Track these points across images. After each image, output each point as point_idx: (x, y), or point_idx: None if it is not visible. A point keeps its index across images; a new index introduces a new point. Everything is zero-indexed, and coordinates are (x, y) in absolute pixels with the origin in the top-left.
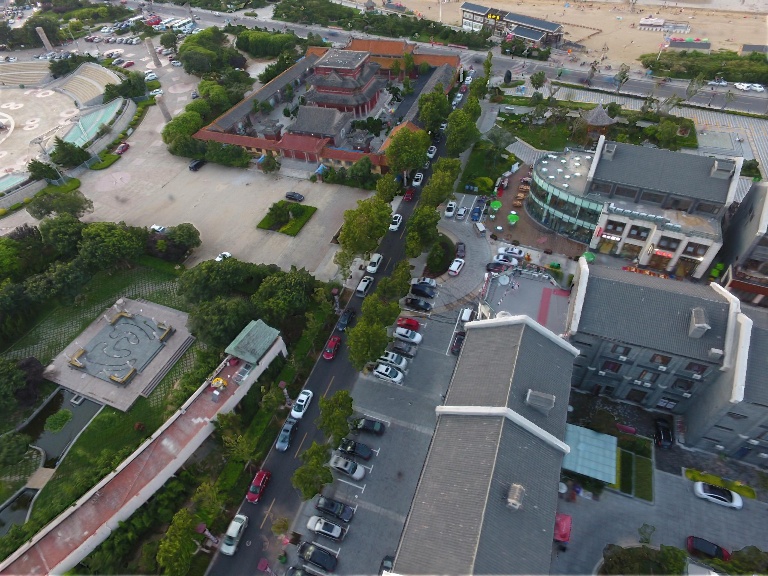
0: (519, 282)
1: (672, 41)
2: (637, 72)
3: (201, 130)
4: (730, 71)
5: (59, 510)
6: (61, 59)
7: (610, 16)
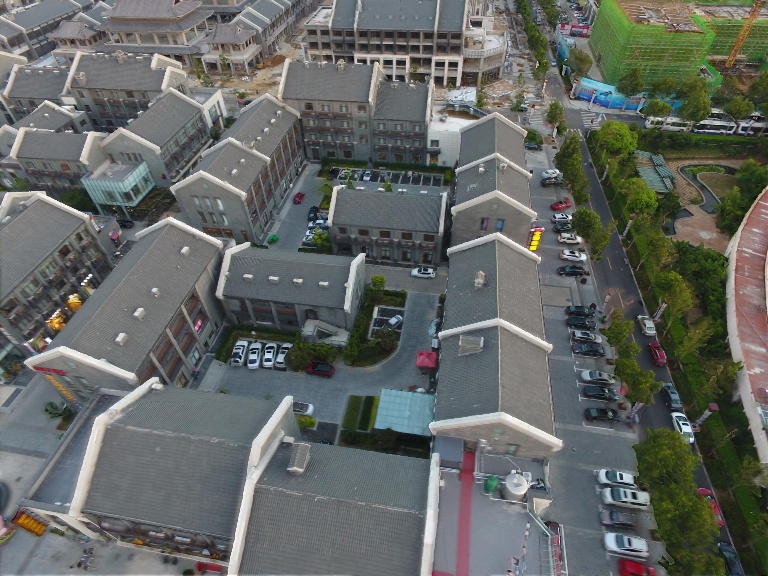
0: None
1: None
2: None
3: None
4: None
5: None
6: None
7: None
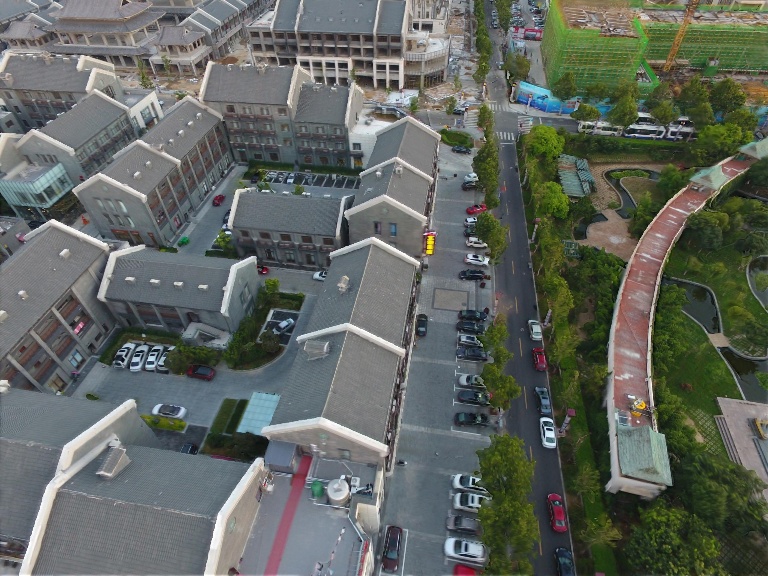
0: None
1: None
2: None
3: None
4: None
5: (669, 314)
6: None
7: None
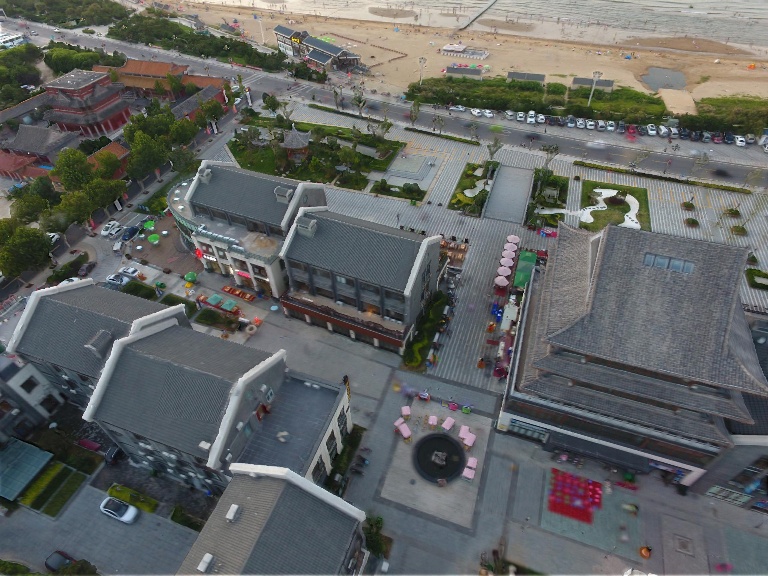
0: None
1: (449, 67)
2: (395, 96)
3: None
4: (469, 97)
5: None
6: None
7: (428, 41)
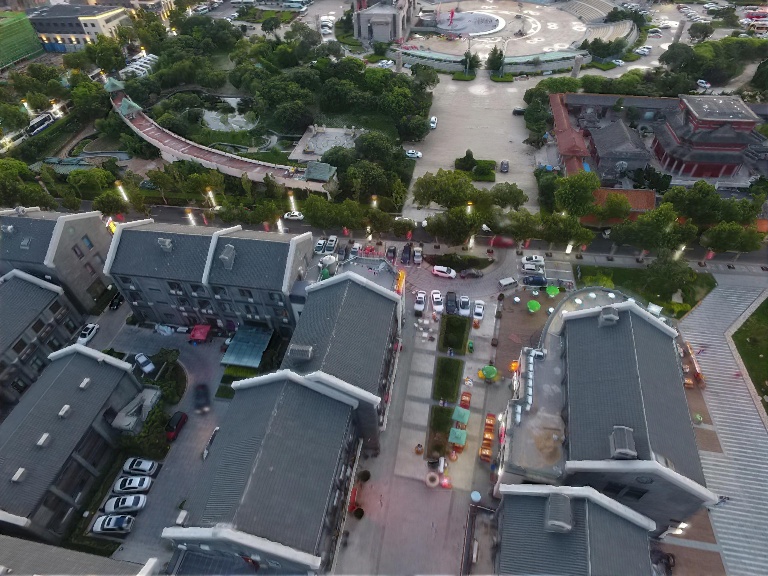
0: (386, 278)
1: None
2: None
3: (558, 93)
4: None
5: None
6: (630, 11)
7: None
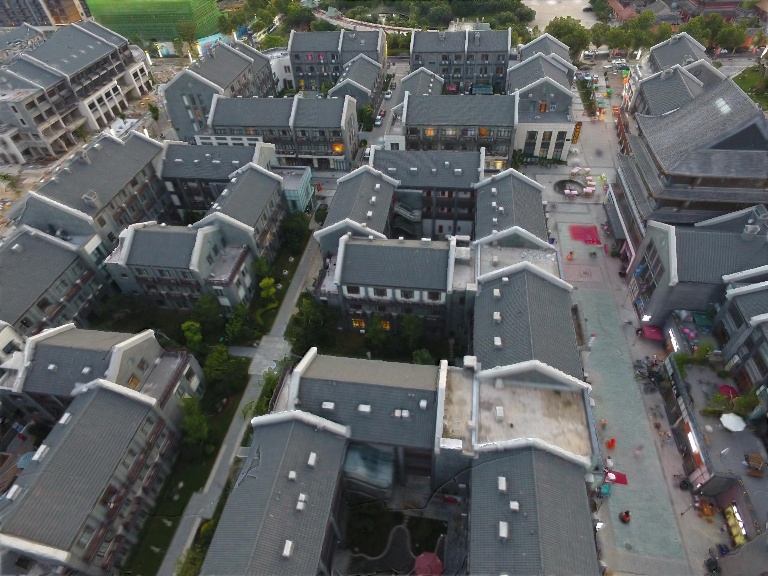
0: None
1: None
2: None
3: None
4: None
5: None
6: None
7: None
